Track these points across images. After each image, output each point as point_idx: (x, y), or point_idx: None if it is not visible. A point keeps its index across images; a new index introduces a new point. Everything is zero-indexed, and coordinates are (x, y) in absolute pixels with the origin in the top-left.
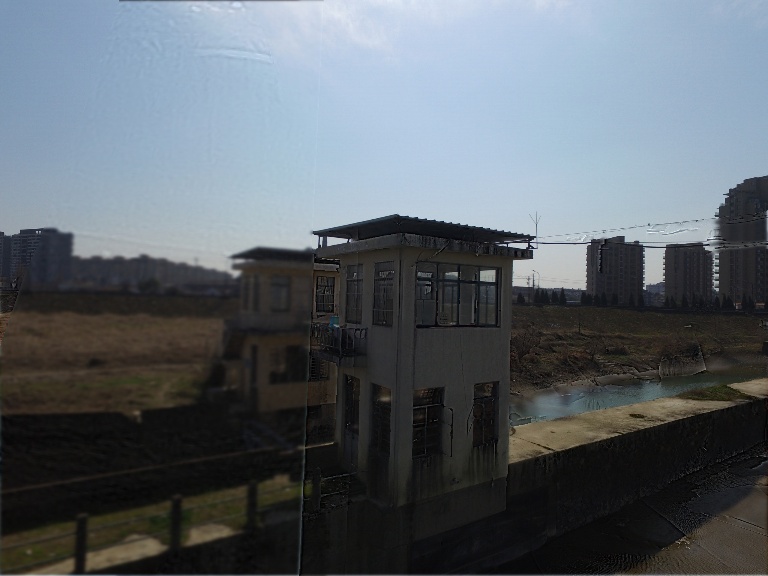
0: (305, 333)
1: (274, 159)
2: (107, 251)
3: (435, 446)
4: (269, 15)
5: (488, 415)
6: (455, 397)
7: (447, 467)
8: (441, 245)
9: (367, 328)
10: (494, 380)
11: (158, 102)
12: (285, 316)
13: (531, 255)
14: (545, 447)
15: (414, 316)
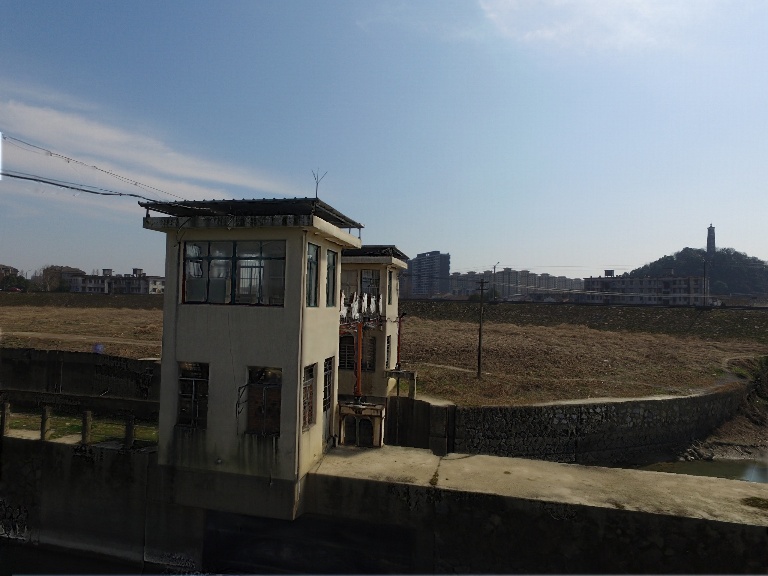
0: None
1: None
2: None
3: (205, 421)
4: None
5: (274, 405)
6: (222, 376)
7: (212, 444)
8: (185, 223)
9: None
10: (275, 366)
11: None
12: None
13: (311, 221)
14: (432, 479)
15: (176, 292)
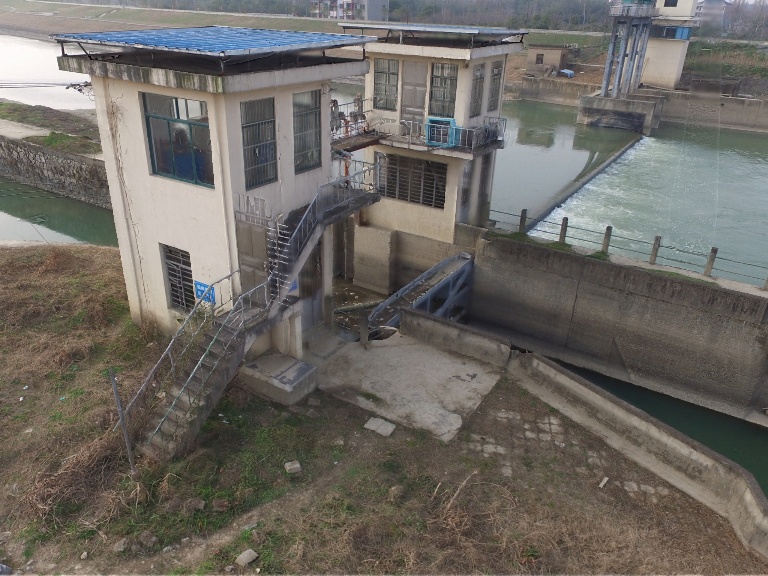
0: (689, 90)
1: (698, 65)
2: (715, 82)
3: None
4: (704, 42)
5: None
6: None
7: None
8: None
9: (486, 116)
10: None
11: (715, 59)
12: (692, 88)
13: None
14: None
15: None
